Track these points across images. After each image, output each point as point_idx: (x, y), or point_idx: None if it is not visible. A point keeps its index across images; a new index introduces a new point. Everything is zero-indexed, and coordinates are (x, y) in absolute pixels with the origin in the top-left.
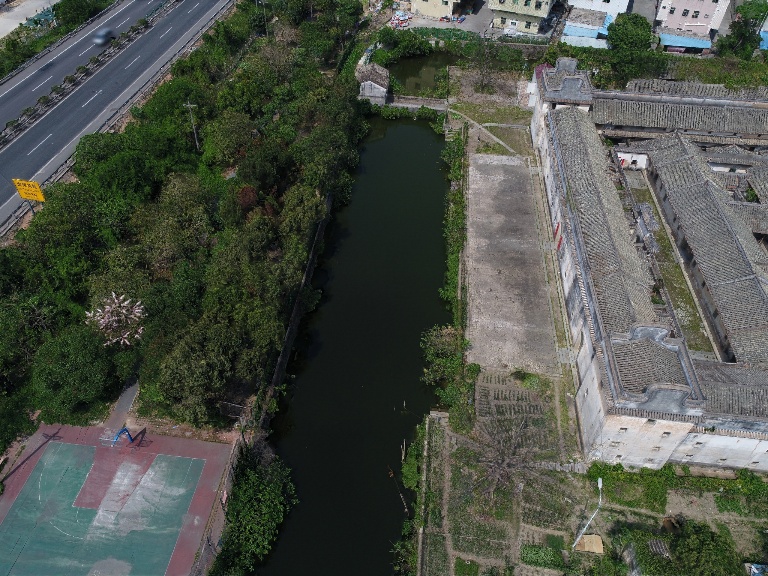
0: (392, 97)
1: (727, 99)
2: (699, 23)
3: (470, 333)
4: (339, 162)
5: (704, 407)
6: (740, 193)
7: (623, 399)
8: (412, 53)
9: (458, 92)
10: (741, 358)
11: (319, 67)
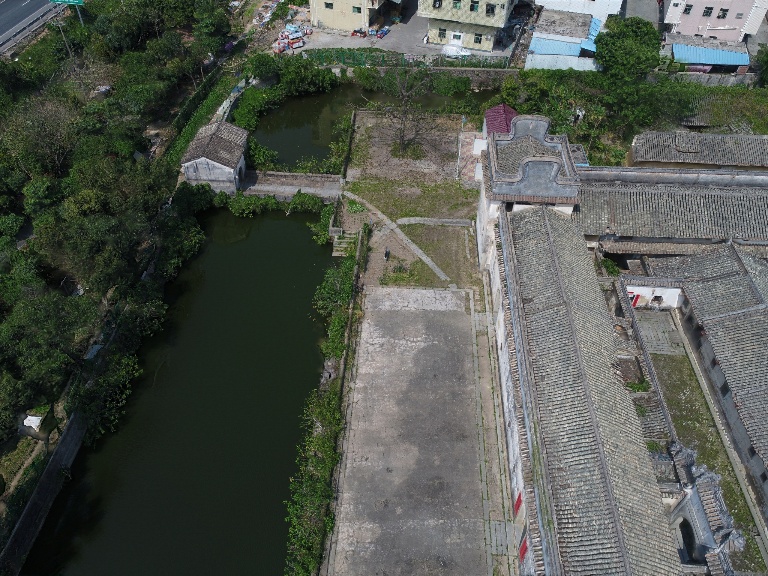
0: (254, 174)
1: None
2: (728, 26)
3: None
4: (119, 330)
5: None
6: None
7: None
8: (303, 90)
9: (365, 158)
10: None
11: (149, 123)
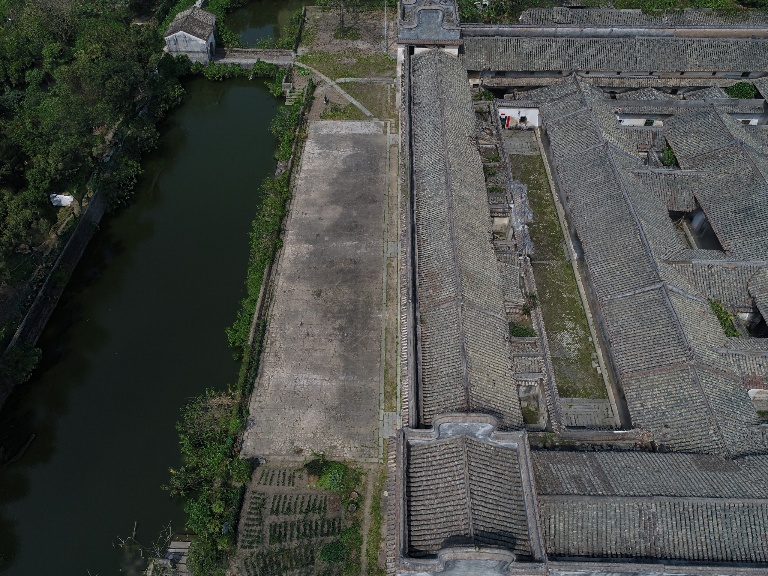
0: (223, 51)
1: (640, 27)
2: None
3: (256, 399)
4: (125, 146)
5: (543, 572)
6: (655, 154)
7: (403, 569)
8: None
9: (312, 39)
10: (638, 419)
11: (135, 17)
